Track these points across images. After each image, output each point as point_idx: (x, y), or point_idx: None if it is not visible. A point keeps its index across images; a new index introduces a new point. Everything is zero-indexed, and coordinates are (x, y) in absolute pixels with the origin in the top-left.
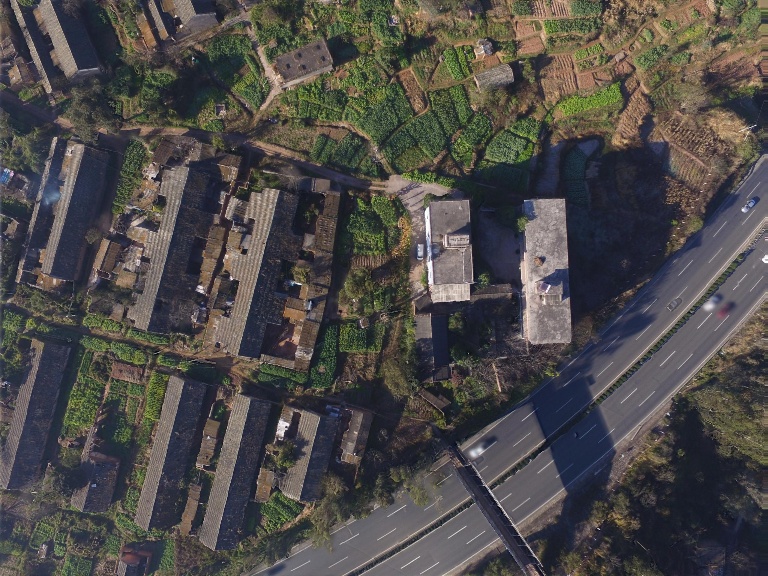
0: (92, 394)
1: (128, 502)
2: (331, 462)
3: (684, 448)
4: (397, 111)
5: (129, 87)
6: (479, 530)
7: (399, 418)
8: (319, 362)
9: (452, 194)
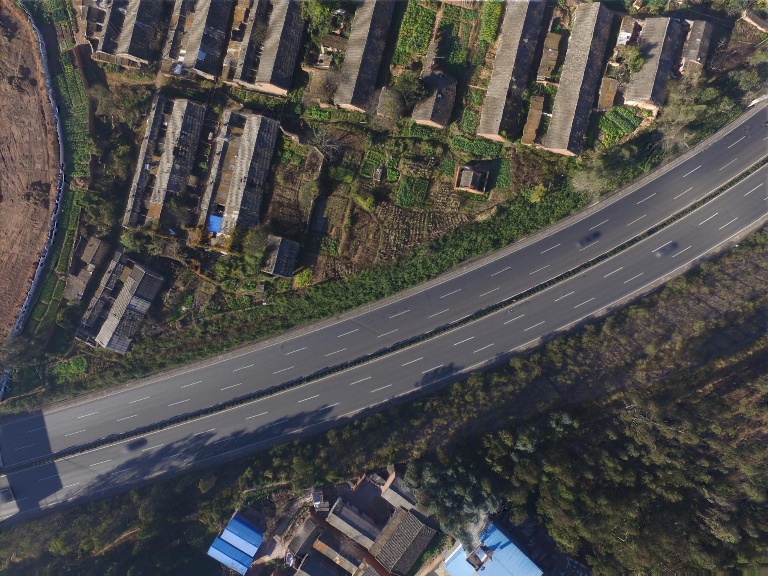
0: (425, 20)
1: (464, 122)
2: None
3: None
4: None
5: None
6: None
7: (727, 41)
8: None
9: None
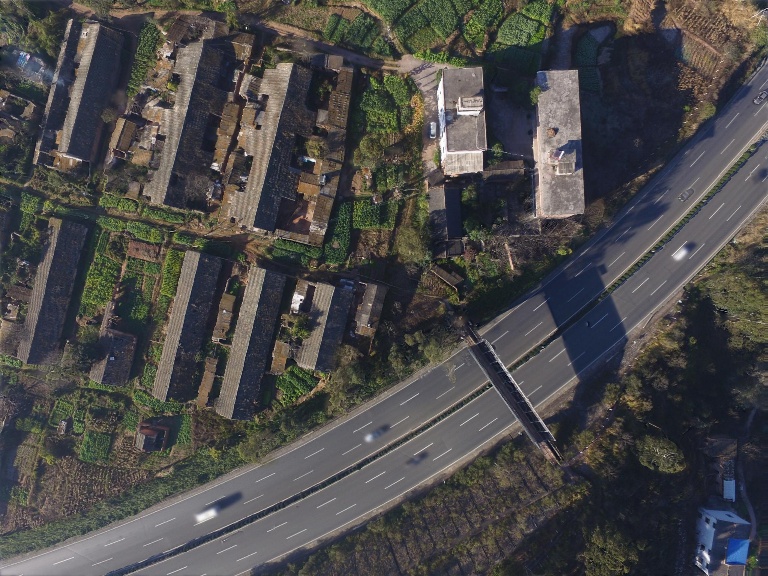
0: (109, 273)
1: (145, 378)
2: (345, 335)
3: (696, 337)
4: None
5: None
6: (491, 417)
7: (412, 295)
8: (333, 238)
9: None
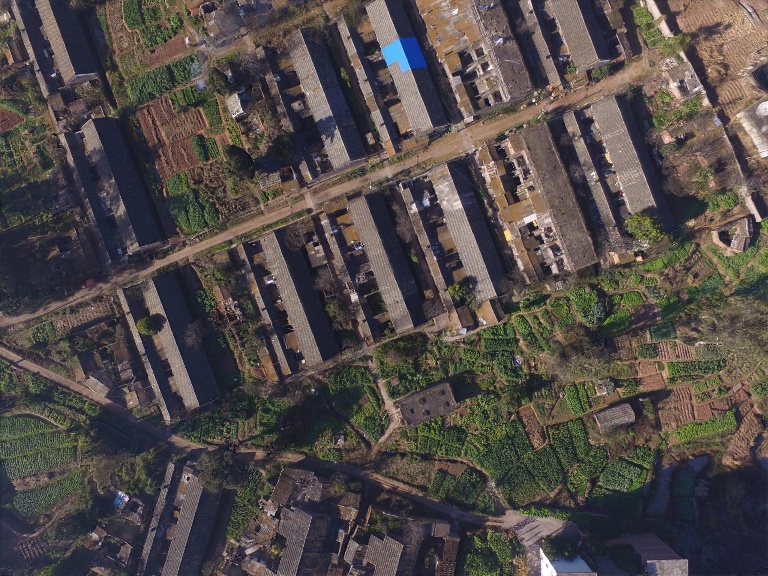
0: None
1: None
2: None
3: None
4: (516, 448)
5: (246, 411)
6: None
7: None
8: None
9: (567, 527)
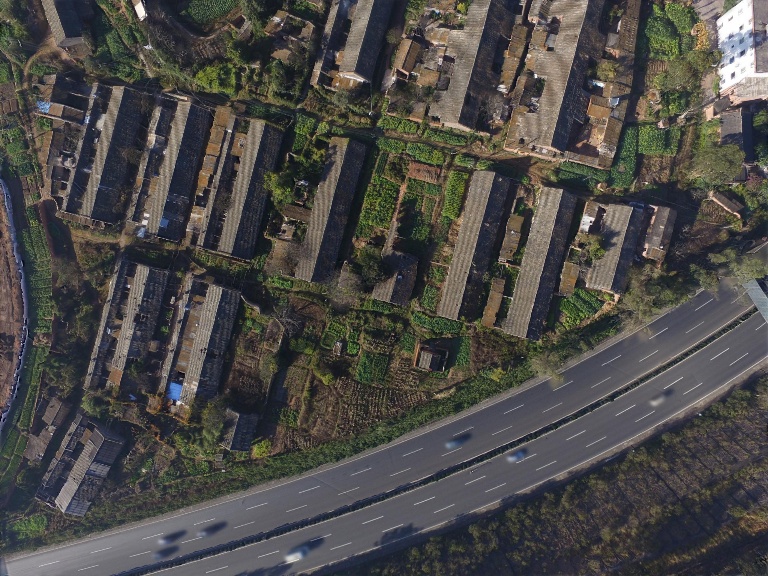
0: (388, 194)
1: (425, 299)
2: None
3: None
4: None
5: None
6: (741, 352)
7: (693, 221)
8: (619, 162)
9: None
